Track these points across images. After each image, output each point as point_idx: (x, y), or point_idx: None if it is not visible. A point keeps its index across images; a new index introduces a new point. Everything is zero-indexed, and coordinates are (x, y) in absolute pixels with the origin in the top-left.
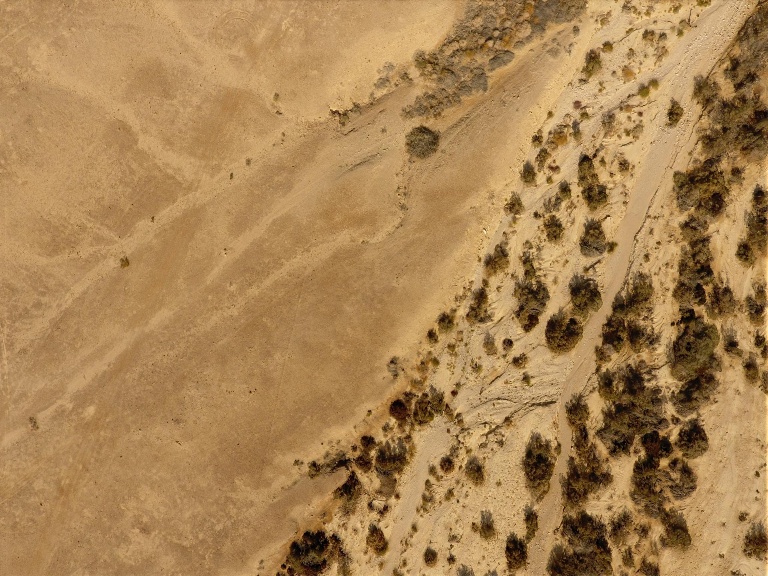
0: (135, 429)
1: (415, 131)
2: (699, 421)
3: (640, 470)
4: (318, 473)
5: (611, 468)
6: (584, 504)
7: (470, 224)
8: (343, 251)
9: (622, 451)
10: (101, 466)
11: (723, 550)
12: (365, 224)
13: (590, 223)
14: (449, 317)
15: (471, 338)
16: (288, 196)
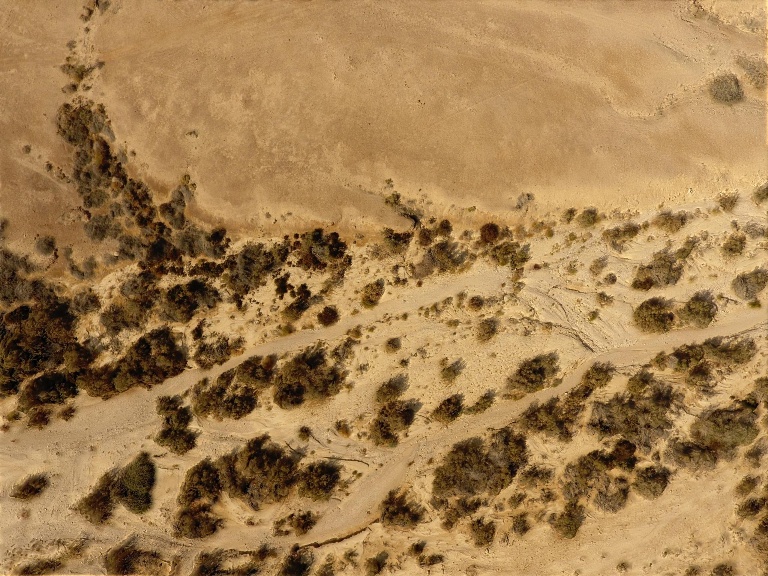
0: (319, 34)
1: (729, 72)
2: (670, 477)
3: (595, 457)
4: (394, 205)
5: (577, 434)
6: (531, 434)
7: (689, 173)
8: (588, 89)
9: (600, 431)
10: (270, 30)
11: (581, 572)
12: (623, 89)
13: (762, 271)
14: (597, 215)
15: (592, 246)
16: (598, 11)
